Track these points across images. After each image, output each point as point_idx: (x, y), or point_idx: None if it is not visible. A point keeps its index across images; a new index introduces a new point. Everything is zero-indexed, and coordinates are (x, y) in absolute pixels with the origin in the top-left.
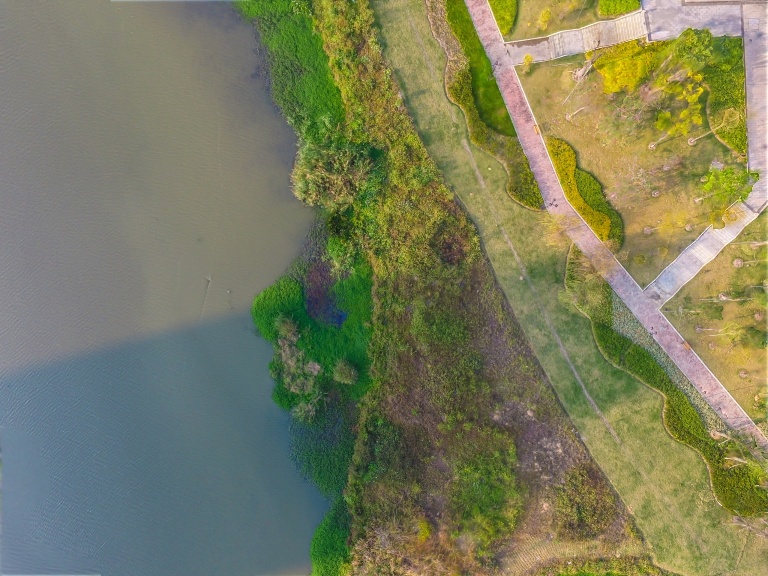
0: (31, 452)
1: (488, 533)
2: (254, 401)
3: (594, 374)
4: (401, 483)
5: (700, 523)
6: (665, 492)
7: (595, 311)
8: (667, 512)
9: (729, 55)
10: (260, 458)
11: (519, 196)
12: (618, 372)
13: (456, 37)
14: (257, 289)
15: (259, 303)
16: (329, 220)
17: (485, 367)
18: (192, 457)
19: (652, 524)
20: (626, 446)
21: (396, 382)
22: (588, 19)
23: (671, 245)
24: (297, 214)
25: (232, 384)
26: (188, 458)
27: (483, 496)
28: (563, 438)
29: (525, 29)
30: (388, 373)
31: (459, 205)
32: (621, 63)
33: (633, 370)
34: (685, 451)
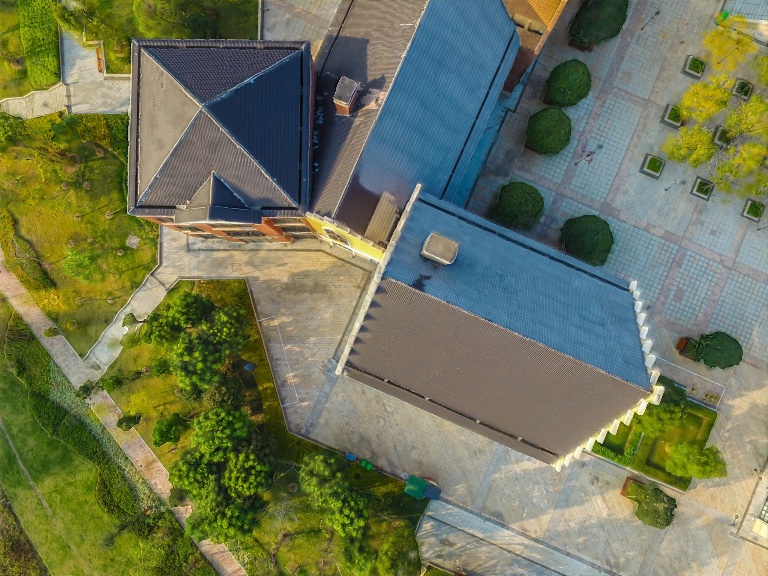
0: None
1: None
2: None
3: (29, 443)
4: None
5: None
6: (95, 567)
7: (33, 379)
8: None
9: None
10: None
11: None
12: (54, 442)
13: None
14: None
15: None
16: None
17: None
18: None
19: None
20: (58, 518)
21: None
22: (27, 88)
23: (99, 317)
24: None
25: None
26: None
27: None
28: None
29: None
30: None
31: None
32: None
33: (67, 441)
34: None
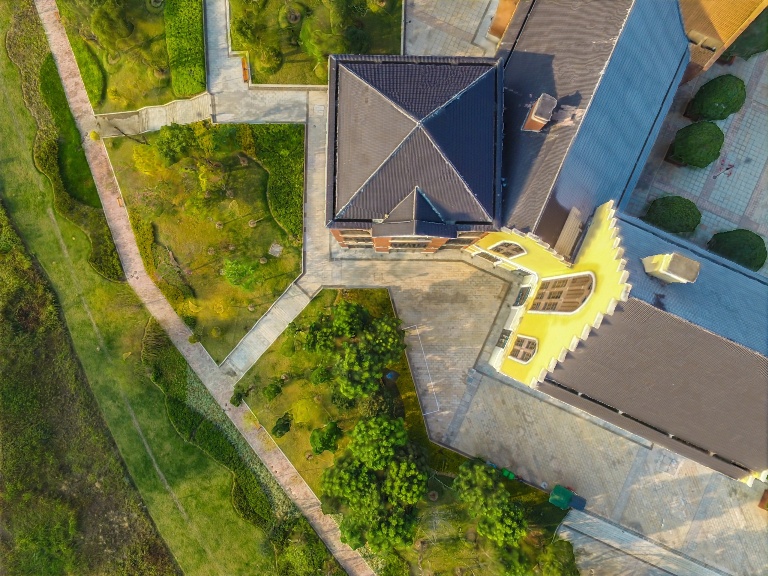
0: None
1: None
2: None
3: (166, 448)
4: None
5: None
6: (230, 571)
7: (169, 385)
8: None
9: (288, 140)
10: None
11: (98, 267)
12: (190, 447)
13: (48, 107)
14: None
15: None
16: None
17: (55, 437)
18: None
19: None
20: (193, 523)
21: None
22: (168, 97)
23: (238, 324)
24: None
25: None
26: None
27: (42, 568)
28: (130, 512)
29: (114, 103)
30: None
31: (40, 273)
32: (134, 150)
33: (203, 446)
34: (252, 530)
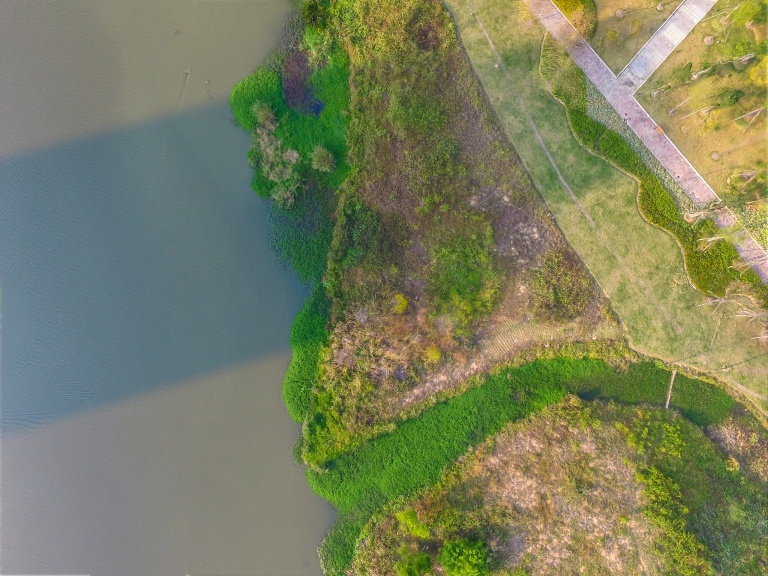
0: (16, 291)
1: (465, 312)
2: (233, 190)
3: (569, 160)
4: (379, 267)
5: (675, 305)
6: (640, 275)
7: (569, 98)
8: (642, 295)
9: None
10: (240, 247)
11: None
12: (593, 158)
13: None
14: (235, 79)
15: (237, 92)
16: (306, 8)
17: (461, 153)
18: (172, 246)
19: (627, 307)
20: (601, 230)
21: (374, 169)
22: None
23: (643, 27)
24: (274, 5)
25: (212, 175)
26: (168, 247)
27: (461, 279)
28: (539, 223)
29: None
30: (366, 160)
31: None
32: None
33: (607, 155)
34: (659, 235)
